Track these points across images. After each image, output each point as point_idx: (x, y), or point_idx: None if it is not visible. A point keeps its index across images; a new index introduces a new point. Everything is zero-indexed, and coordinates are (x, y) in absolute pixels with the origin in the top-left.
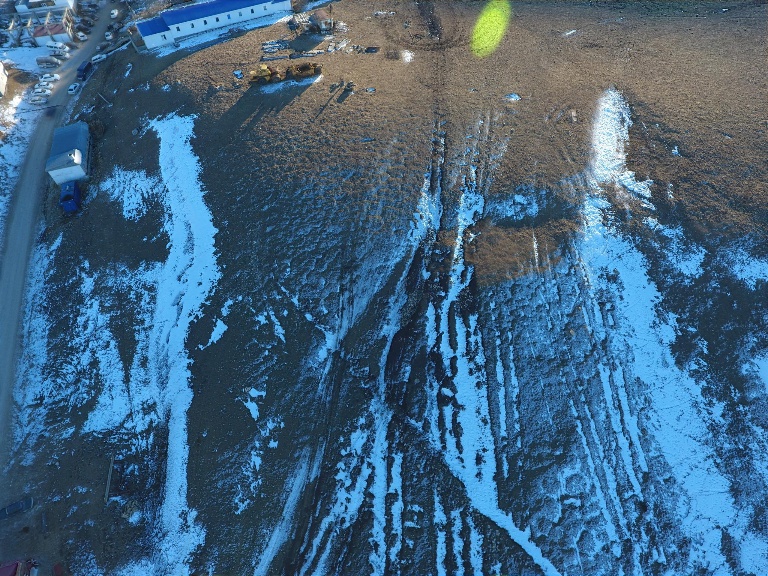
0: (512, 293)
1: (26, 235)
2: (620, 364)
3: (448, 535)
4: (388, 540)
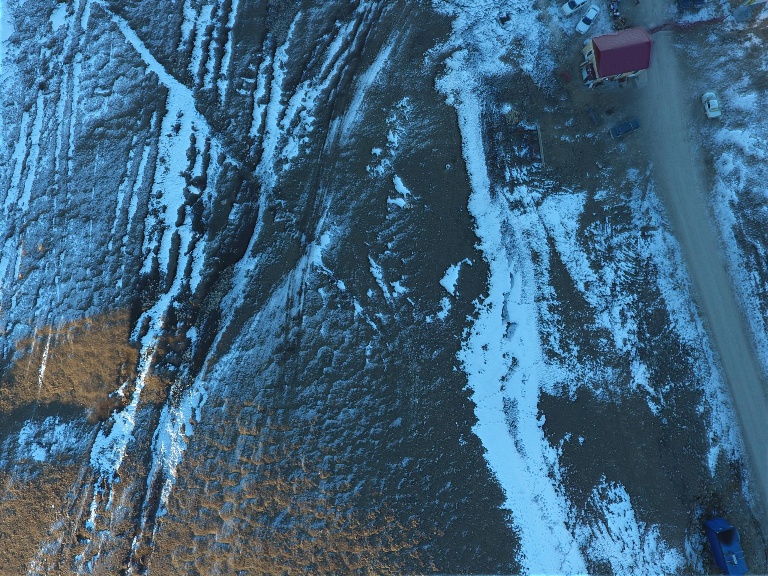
0: (92, 298)
1: (766, 479)
2: (4, 209)
3: (217, 71)
4: (270, 70)
